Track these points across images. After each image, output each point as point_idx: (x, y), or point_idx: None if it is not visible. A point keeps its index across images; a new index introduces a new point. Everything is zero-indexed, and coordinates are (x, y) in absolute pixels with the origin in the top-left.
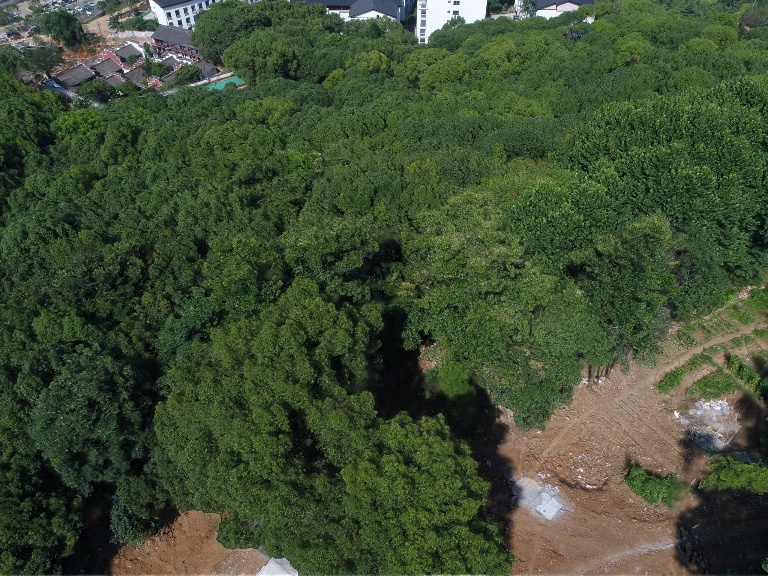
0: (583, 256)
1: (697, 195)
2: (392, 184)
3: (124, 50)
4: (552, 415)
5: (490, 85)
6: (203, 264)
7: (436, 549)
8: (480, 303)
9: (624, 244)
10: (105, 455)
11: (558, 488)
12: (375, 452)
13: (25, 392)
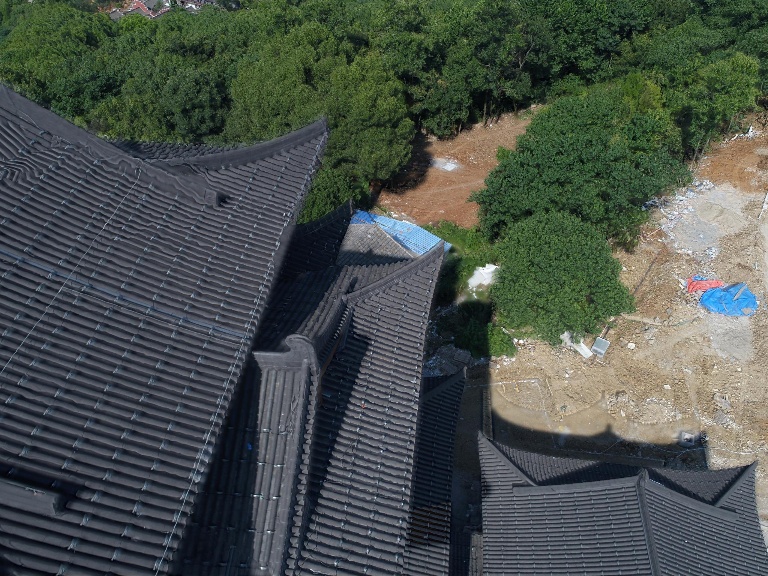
0: (468, 21)
1: (546, 5)
2: (364, 15)
3: (150, 2)
4: (459, 137)
5: (448, 1)
6: (247, 48)
7: (374, 103)
8: (406, 33)
9: (485, 3)
10: (202, 114)
11: (456, 160)
12: (346, 68)
13: (159, 79)
